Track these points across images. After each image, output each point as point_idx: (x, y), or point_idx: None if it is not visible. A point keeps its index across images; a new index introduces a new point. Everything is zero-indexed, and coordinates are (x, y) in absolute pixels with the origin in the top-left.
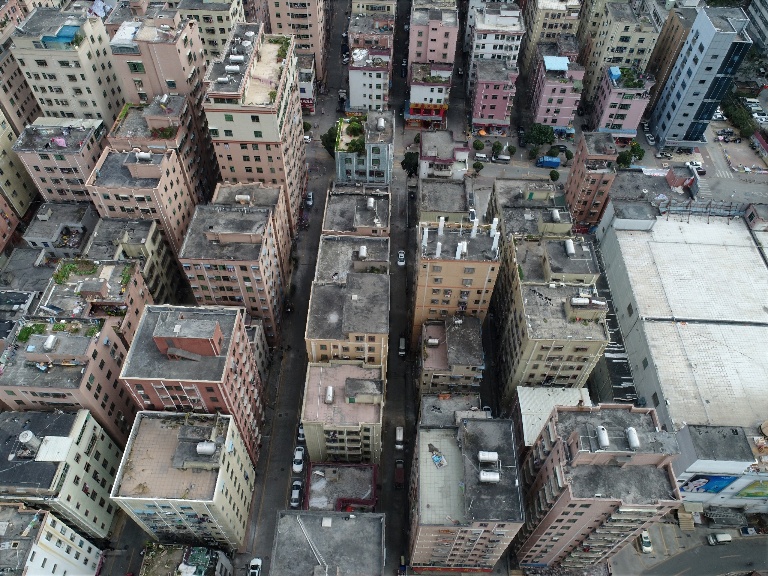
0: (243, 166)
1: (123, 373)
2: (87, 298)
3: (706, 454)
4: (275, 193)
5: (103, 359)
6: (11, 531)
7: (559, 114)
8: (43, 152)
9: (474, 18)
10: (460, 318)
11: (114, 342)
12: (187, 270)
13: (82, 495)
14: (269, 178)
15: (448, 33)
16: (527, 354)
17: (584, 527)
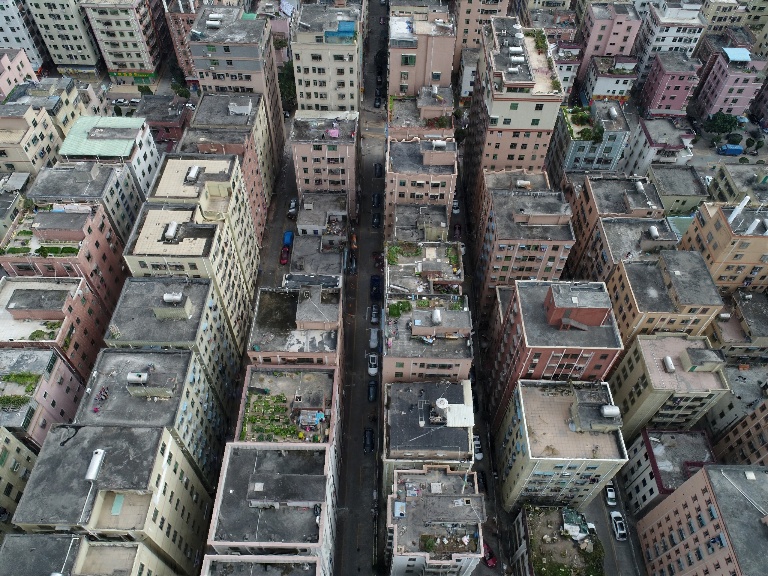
0: (507, 154)
1: (527, 342)
2: (429, 277)
3: None
4: (540, 179)
5: None
6: (446, 491)
7: (736, 104)
8: (319, 143)
9: (654, 12)
10: (746, 293)
11: None
12: (500, 251)
13: None
14: (527, 165)
15: (631, 27)
16: None
17: None
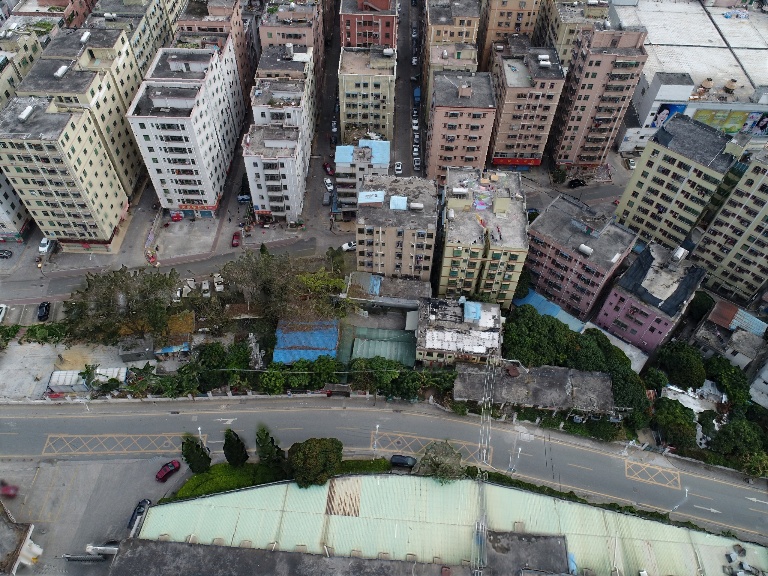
0: None
1: None
2: (297, 2)
3: (666, 83)
4: None
5: (315, 27)
6: None
7: None
8: None
9: None
10: None
11: (317, 24)
12: None
13: (310, 95)
14: None
15: None
16: (560, 38)
17: (596, 96)
